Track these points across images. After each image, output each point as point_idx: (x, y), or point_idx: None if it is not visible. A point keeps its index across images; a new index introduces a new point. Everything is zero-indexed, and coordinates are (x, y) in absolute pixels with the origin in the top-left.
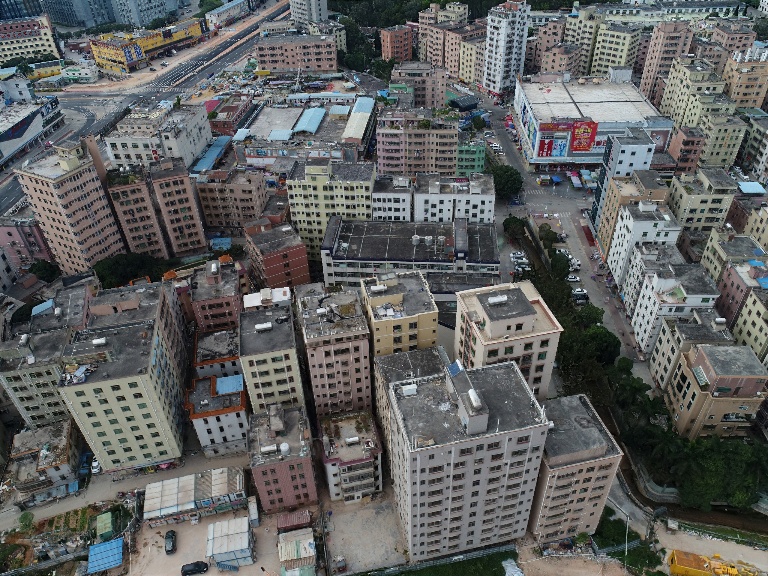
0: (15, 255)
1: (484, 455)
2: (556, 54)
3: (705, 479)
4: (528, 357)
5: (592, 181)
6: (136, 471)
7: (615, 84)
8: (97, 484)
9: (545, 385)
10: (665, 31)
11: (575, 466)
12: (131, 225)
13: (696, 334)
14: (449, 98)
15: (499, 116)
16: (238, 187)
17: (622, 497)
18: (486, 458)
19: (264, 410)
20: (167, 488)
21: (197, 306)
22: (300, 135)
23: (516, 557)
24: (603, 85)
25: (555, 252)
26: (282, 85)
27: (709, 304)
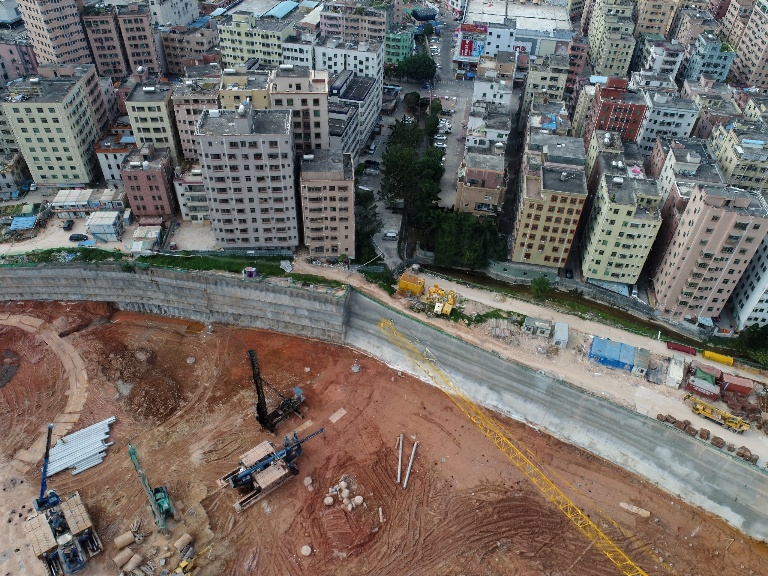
0: (15, 71)
1: (248, 152)
2: None
3: (444, 238)
4: (307, 113)
5: None
6: None
7: (552, 6)
8: (32, 196)
9: (325, 143)
10: None
11: (319, 181)
12: (100, 52)
13: None
14: None
15: (452, 28)
16: (193, 39)
17: (394, 254)
18: (250, 155)
19: None
20: (72, 193)
21: (122, 92)
22: None
23: (292, 260)
24: (541, 6)
25: None
26: None
27: (504, 139)
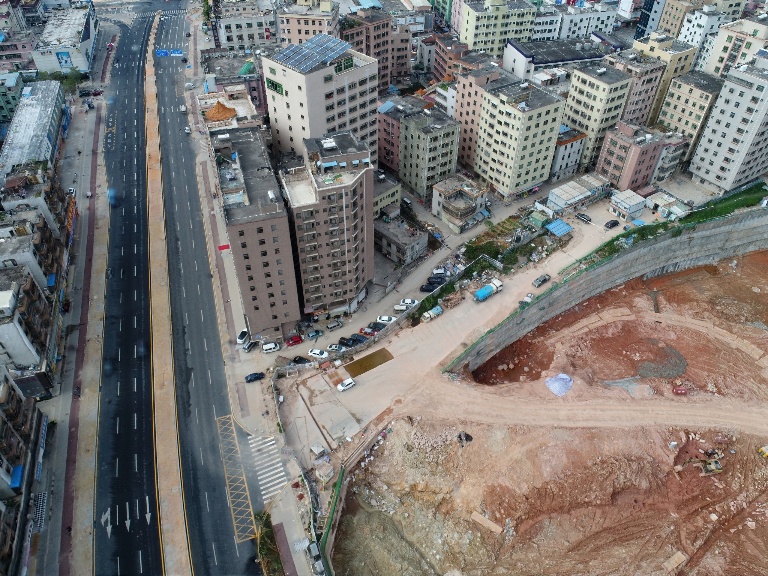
0: None
1: None
2: None
3: None
4: None
5: None
6: (516, 198)
7: None
8: (497, 210)
9: None
10: None
11: None
12: None
13: None
14: None
15: None
16: (398, 37)
17: None
18: None
19: (599, 134)
20: (565, 189)
21: None
22: None
23: (766, 184)
24: None
25: None
26: None
27: None
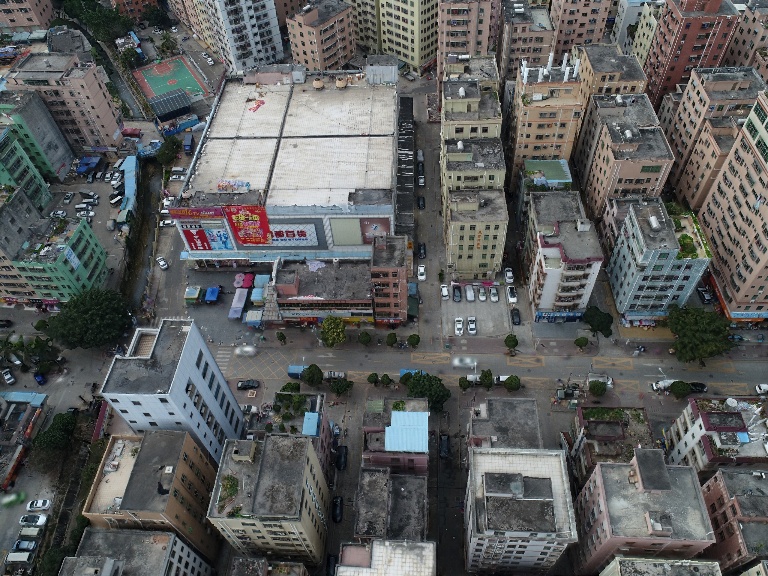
0: None
1: None
2: (301, 24)
3: None
4: None
5: (263, 302)
6: None
7: (371, 89)
8: None
9: None
10: None
11: None
12: None
13: None
14: (175, 83)
15: None
16: None
17: None
18: None
19: None
20: None
21: None
22: None
23: None
24: (351, 91)
25: None
26: None
27: None
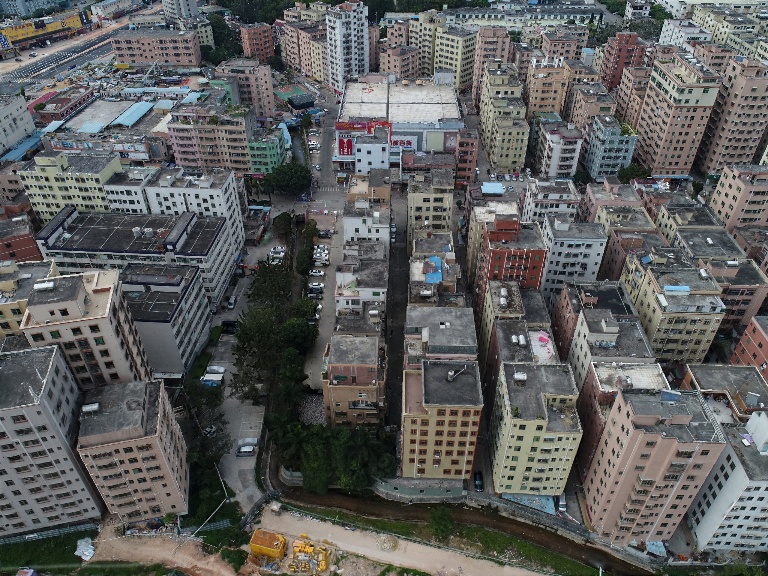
0: None
1: None
2: (390, 55)
3: (309, 463)
4: (84, 342)
5: None
6: None
7: (437, 86)
8: None
9: (123, 370)
10: (485, 36)
11: (106, 446)
12: None
13: (351, 325)
14: None
15: (334, 115)
16: (4, 177)
17: (250, 481)
18: None
19: None
20: None
21: None
22: (117, 128)
23: (94, 536)
24: (425, 87)
25: (312, 247)
26: (138, 79)
27: (381, 297)
